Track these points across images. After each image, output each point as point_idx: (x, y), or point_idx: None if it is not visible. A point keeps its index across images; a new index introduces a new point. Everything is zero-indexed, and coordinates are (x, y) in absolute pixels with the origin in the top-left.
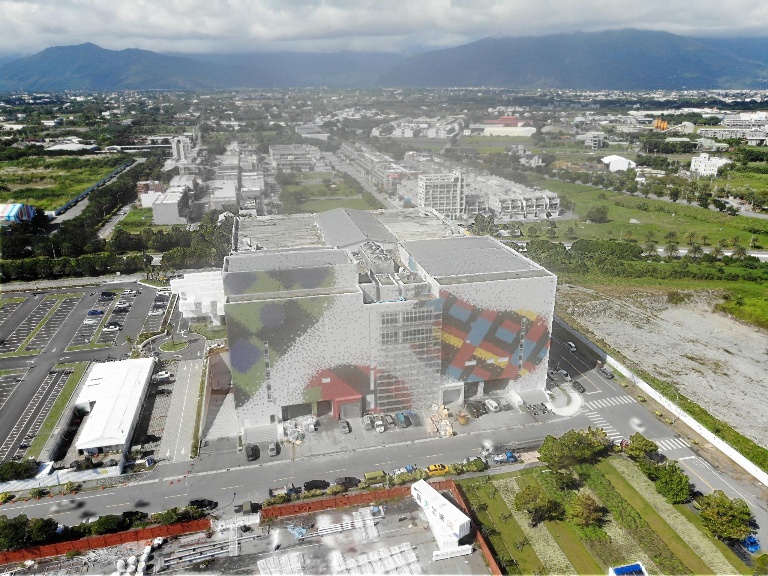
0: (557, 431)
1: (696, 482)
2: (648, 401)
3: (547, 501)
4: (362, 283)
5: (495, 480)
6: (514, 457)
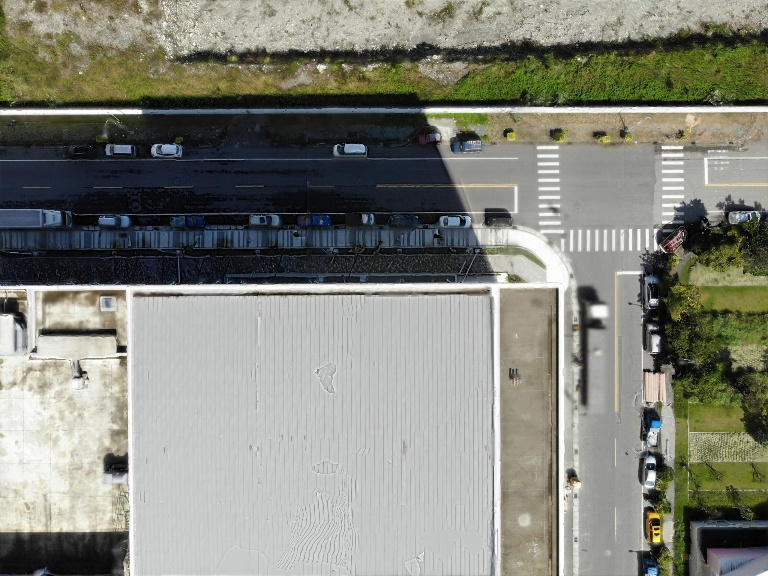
0: (604, 320)
1: (754, 197)
2: (563, 128)
3: (743, 411)
4: None
5: (691, 459)
6: (657, 416)
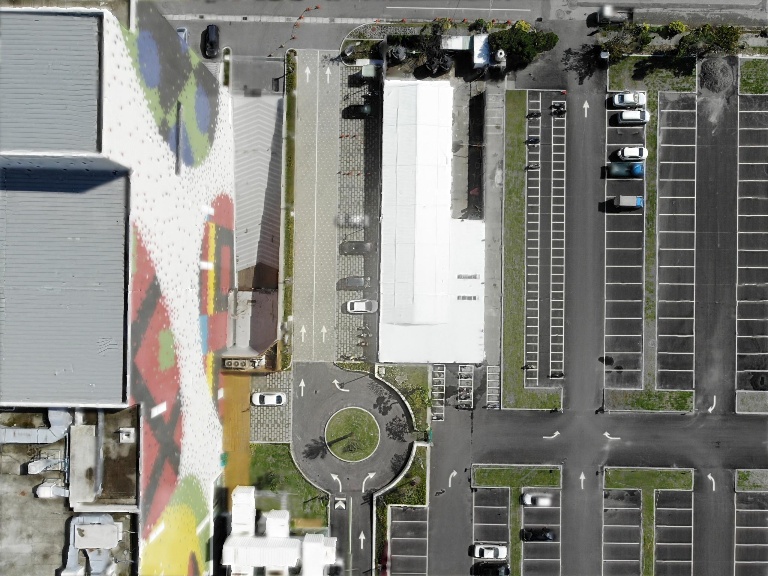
0: None
1: None
2: None
3: None
4: None
5: None
6: None
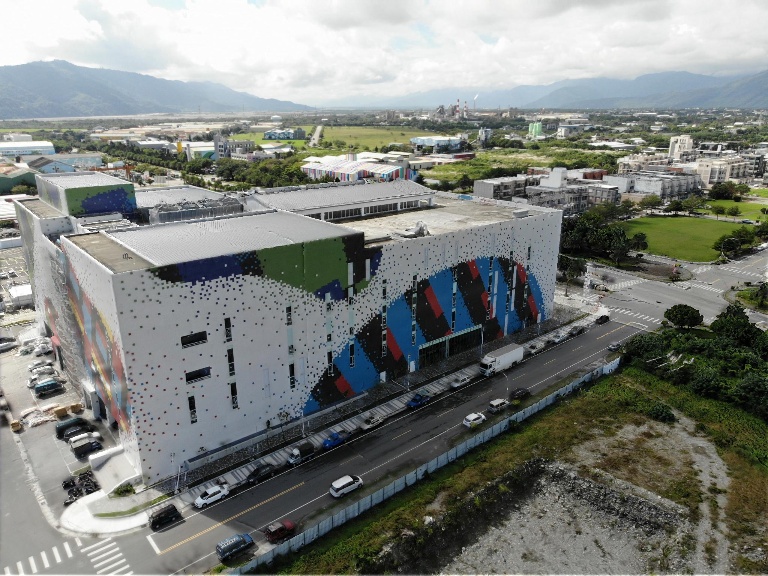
0: (7, 515)
1: None
2: None
3: None
4: None
5: None
6: None
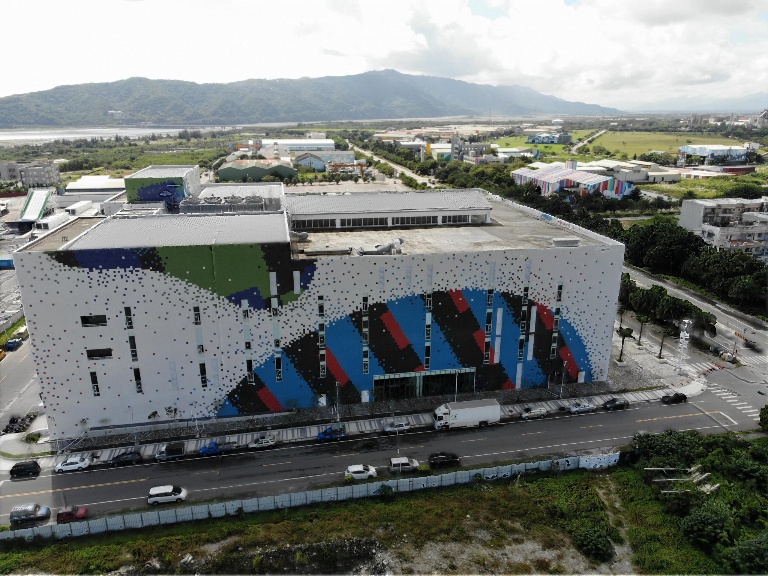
0: None
1: None
2: None
3: None
4: (128, 201)
5: None
6: None
